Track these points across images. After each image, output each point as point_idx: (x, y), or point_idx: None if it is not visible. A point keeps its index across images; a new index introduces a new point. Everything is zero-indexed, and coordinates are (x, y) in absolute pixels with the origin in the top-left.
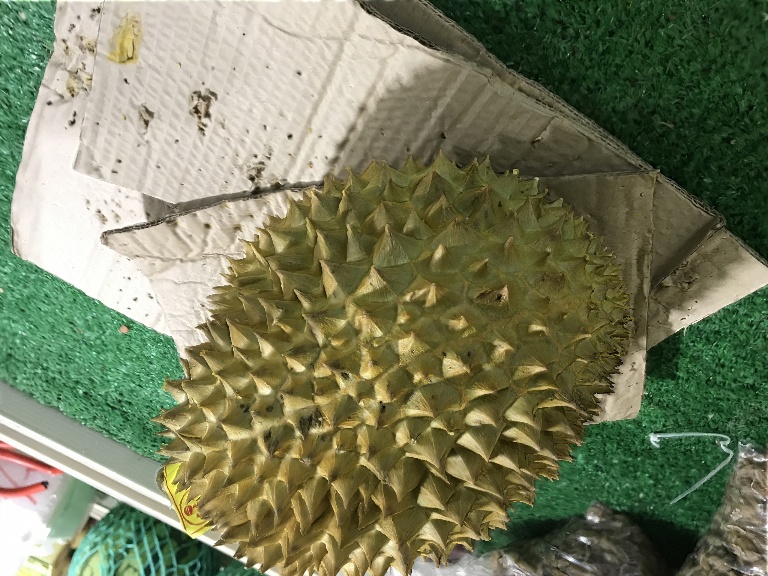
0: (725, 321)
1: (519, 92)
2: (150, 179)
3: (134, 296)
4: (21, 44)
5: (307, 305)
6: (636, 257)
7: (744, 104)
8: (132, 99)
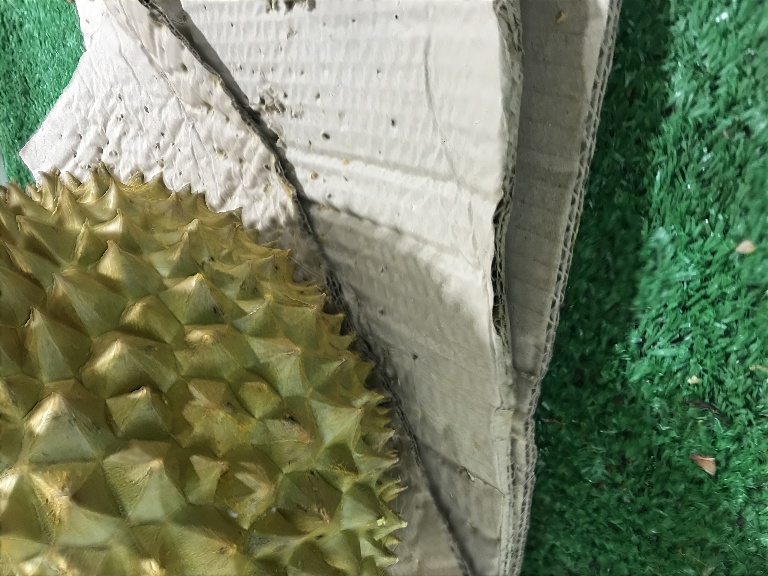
0: None
1: (510, 442)
2: None
3: None
4: None
5: None
6: None
7: None
8: None
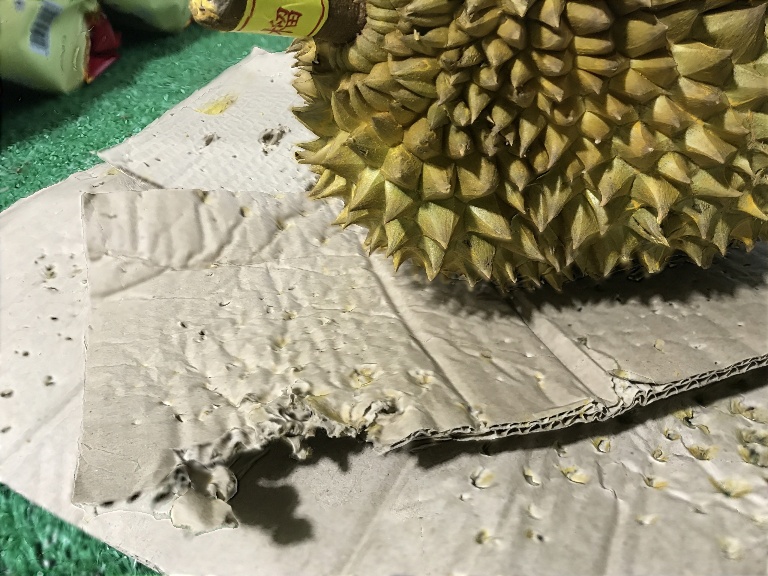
0: None
1: None
2: (185, 179)
3: (8, 389)
4: (71, 167)
5: None
6: None
7: None
8: (202, 130)
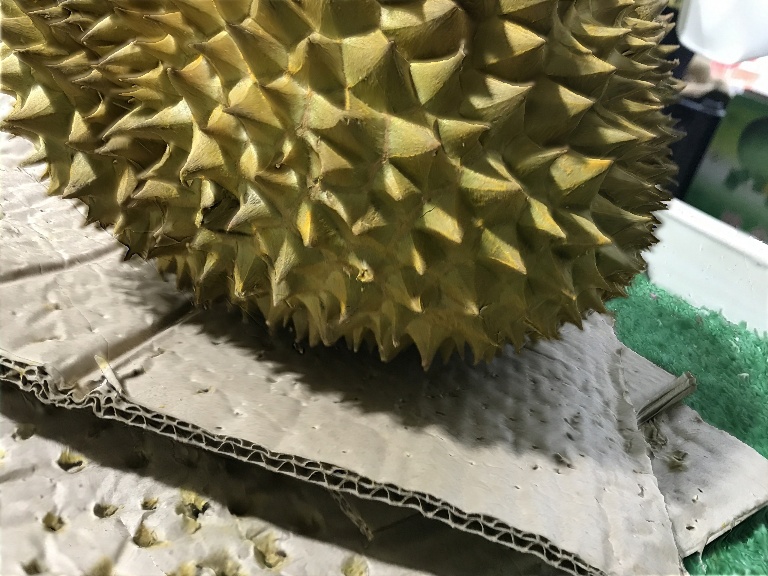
0: (759, 567)
1: None
2: None
3: None
4: None
5: None
6: (607, 370)
7: (665, 357)
8: None
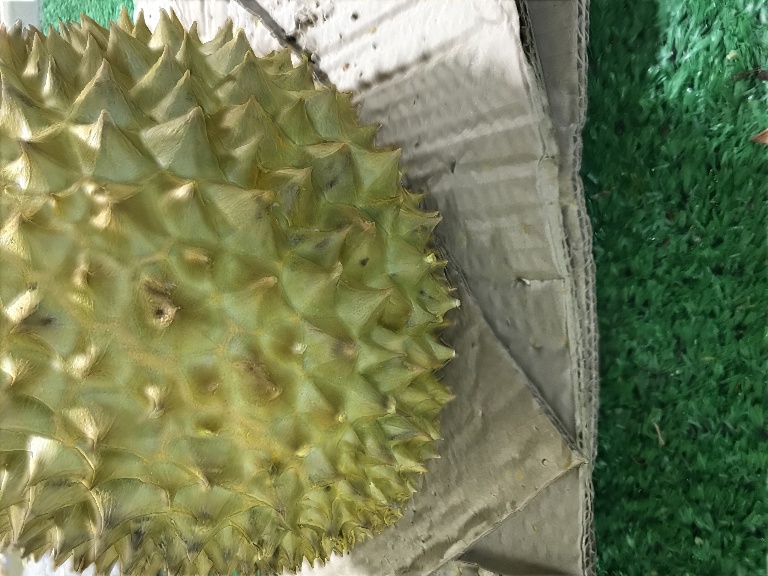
0: None
1: (560, 210)
2: None
3: None
4: None
5: (48, 88)
6: (477, 511)
7: (757, 521)
8: None
